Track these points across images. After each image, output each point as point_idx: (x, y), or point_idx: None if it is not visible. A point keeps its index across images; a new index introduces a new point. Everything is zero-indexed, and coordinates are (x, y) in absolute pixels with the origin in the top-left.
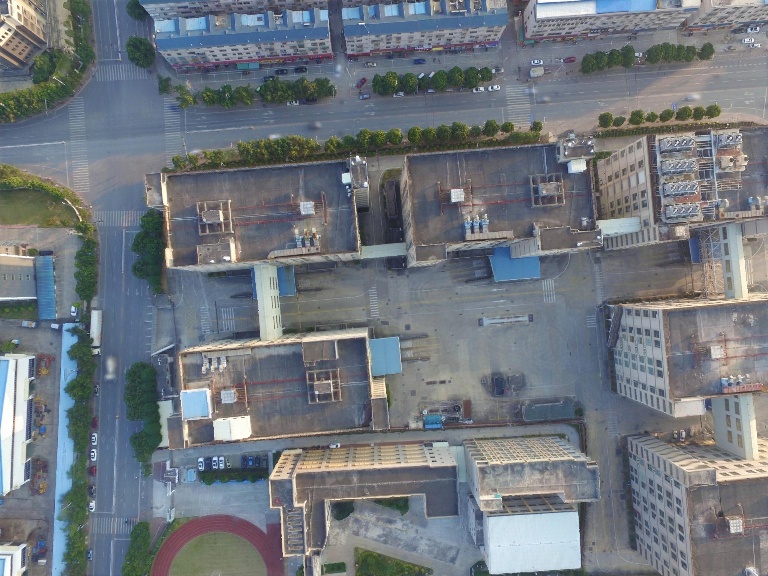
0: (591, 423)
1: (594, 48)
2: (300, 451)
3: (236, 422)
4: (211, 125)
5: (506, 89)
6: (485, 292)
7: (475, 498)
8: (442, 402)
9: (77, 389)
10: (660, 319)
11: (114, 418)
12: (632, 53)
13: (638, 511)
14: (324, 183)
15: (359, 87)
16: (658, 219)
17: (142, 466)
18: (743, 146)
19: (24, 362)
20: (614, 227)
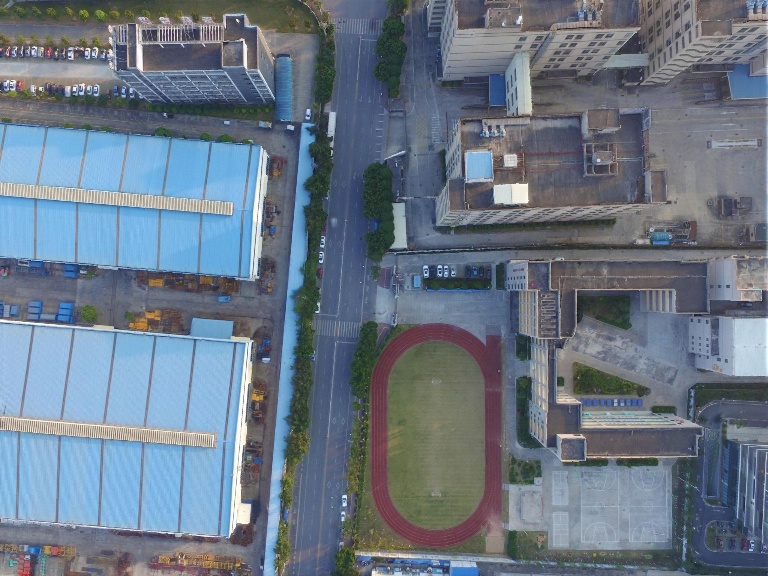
0: None
1: None
2: None
3: (517, 186)
4: None
5: None
6: (715, 115)
7: (723, 297)
8: (667, 222)
9: (319, 182)
10: None
11: (343, 221)
12: None
13: None
14: None
15: None
16: None
17: (372, 267)
18: None
19: (265, 157)
20: None
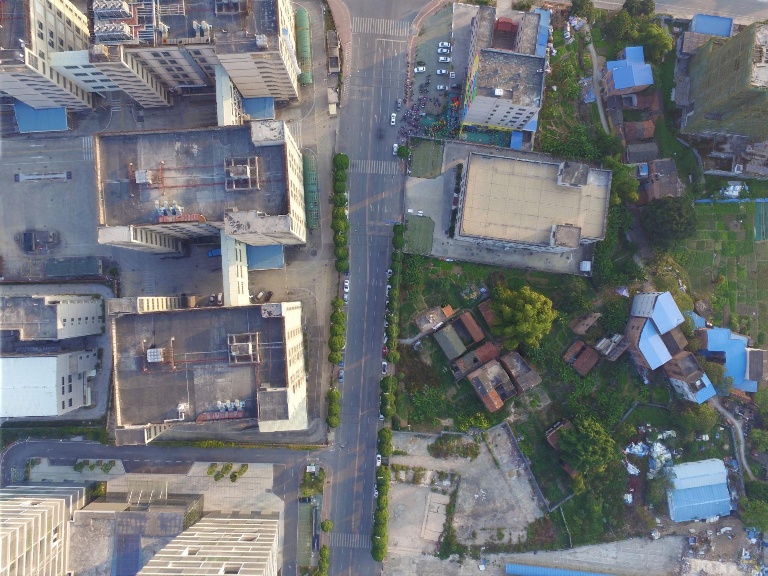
0: (127, 284)
1: None
2: None
3: None
4: None
5: None
6: (23, 148)
7: None
8: None
9: None
10: (98, 145)
11: None
12: None
13: None
14: None
15: None
16: None
17: None
18: None
19: None
20: (76, 58)
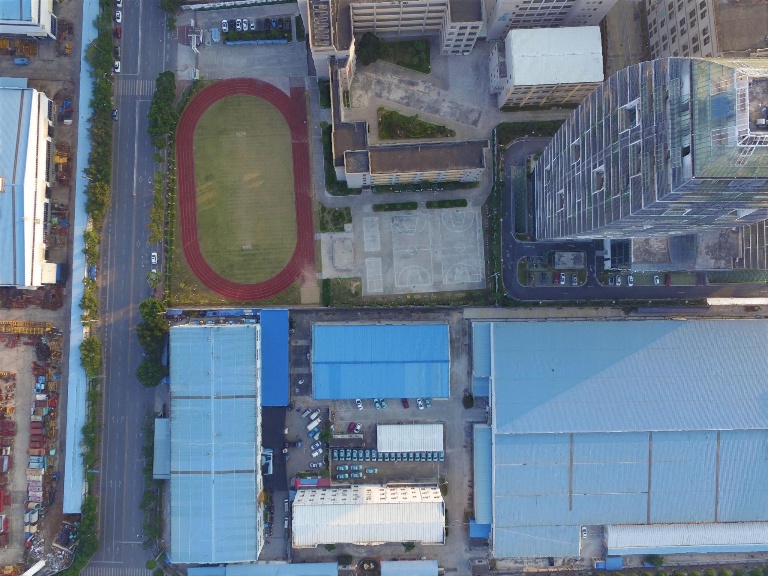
0: None
1: None
2: None
3: None
4: None
5: None
6: None
7: (498, 8)
8: None
9: None
10: None
11: None
12: None
13: None
14: None
15: None
16: None
17: (167, 20)
18: None
19: None
20: None
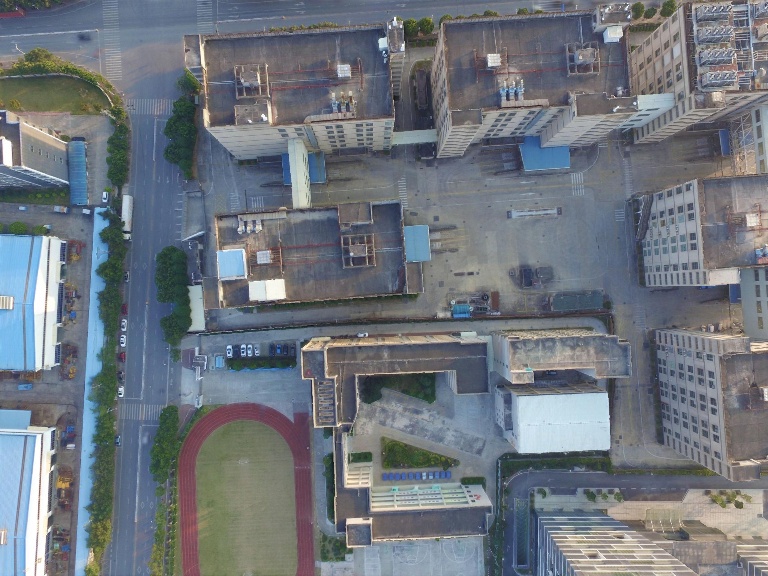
0: (619, 317)
1: None
2: (328, 338)
3: (271, 283)
4: (243, 15)
5: None
6: (514, 184)
7: (505, 376)
8: (470, 293)
9: (109, 270)
10: (695, 189)
11: (144, 304)
12: None
13: (666, 402)
14: (360, 50)
15: None
16: (694, 87)
17: (171, 351)
18: None
19: (56, 244)
20: (648, 102)
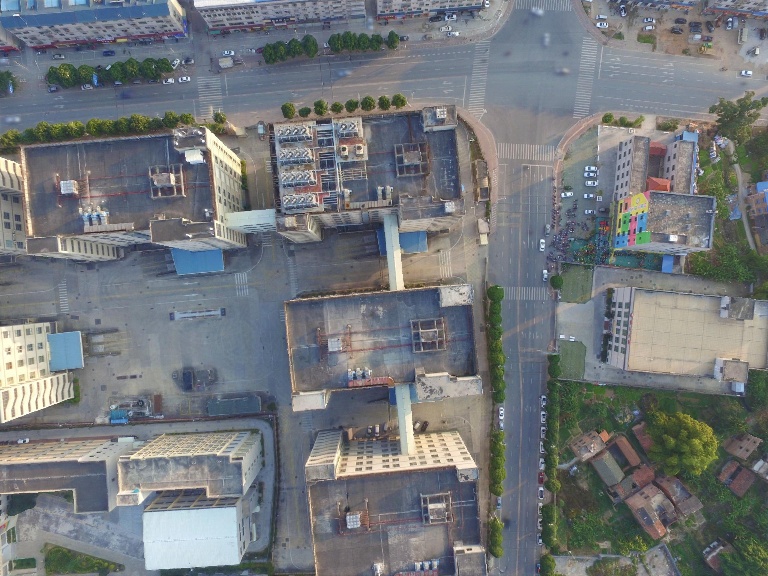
0: (285, 418)
1: (288, 38)
2: None
3: None
4: None
5: (197, 80)
6: (177, 286)
7: None
8: (132, 397)
9: None
10: None
11: None
12: (309, 42)
13: None
14: None
15: (47, 80)
16: None
17: None
18: (372, 135)
19: None
20: (253, 219)
